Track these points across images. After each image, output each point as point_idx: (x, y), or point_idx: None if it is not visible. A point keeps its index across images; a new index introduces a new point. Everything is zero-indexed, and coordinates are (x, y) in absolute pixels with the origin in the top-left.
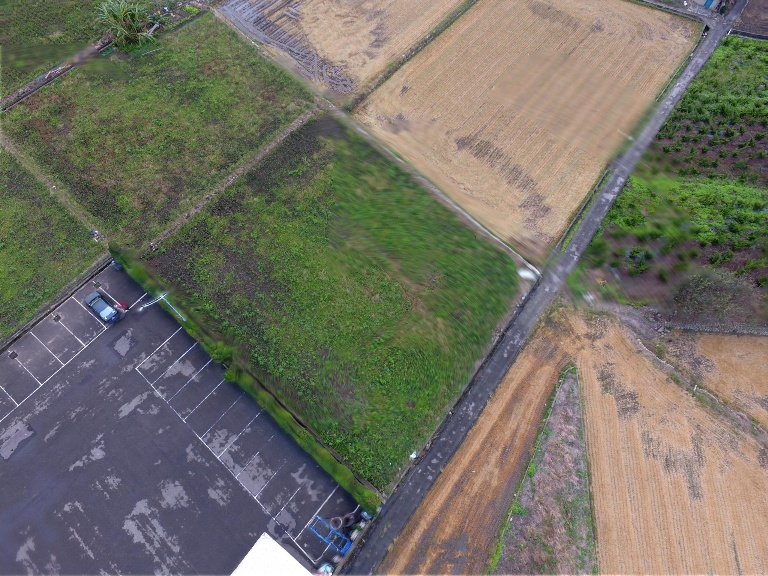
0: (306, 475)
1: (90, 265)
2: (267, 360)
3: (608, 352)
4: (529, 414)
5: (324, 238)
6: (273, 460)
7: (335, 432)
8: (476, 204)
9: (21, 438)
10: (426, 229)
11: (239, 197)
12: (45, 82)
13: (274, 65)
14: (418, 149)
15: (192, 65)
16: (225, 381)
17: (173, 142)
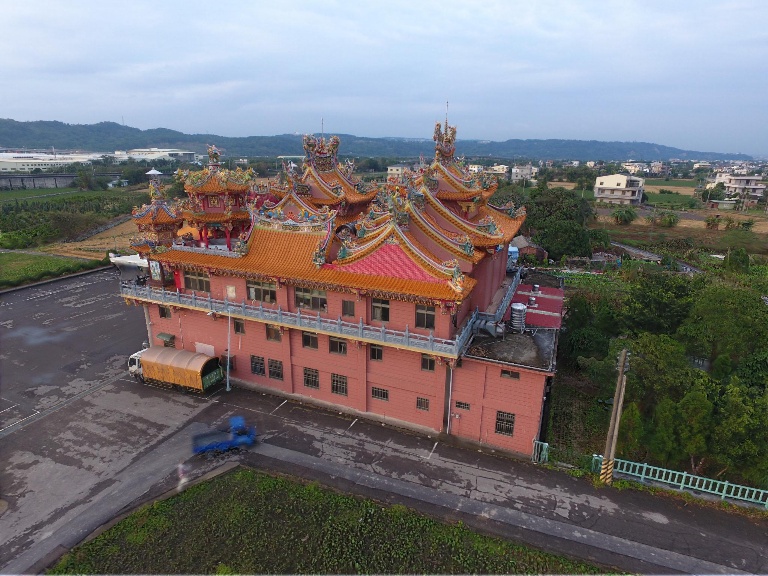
0: None
1: None
2: None
3: (76, 245)
4: (94, 253)
5: None
6: None
7: None
8: None
9: None
10: None
11: None
12: None
13: None
14: None
15: None
16: None
17: None
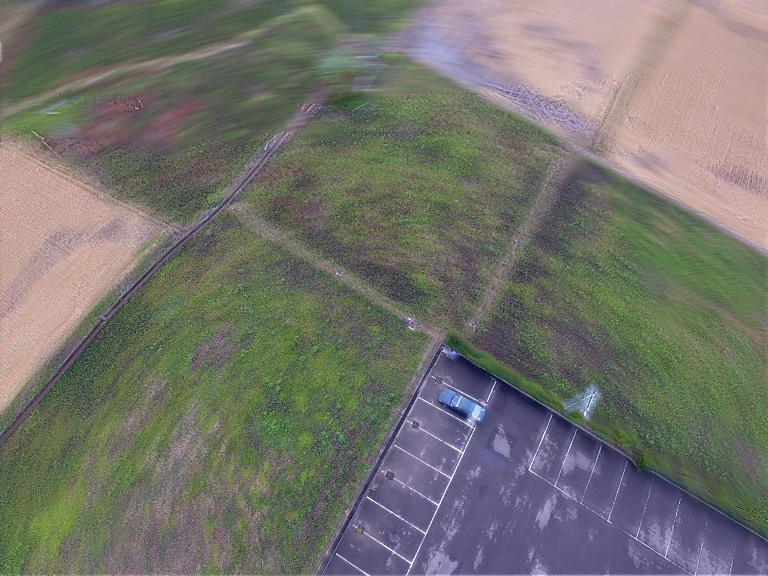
0: (763, 561)
1: (421, 358)
2: (654, 438)
3: None
4: None
5: (643, 293)
6: (722, 550)
7: (763, 507)
8: (763, 235)
9: (449, 571)
10: (737, 269)
11: (533, 259)
12: (265, 154)
13: (498, 108)
14: (677, 182)
15: (412, 117)
16: (638, 471)
17: (436, 206)
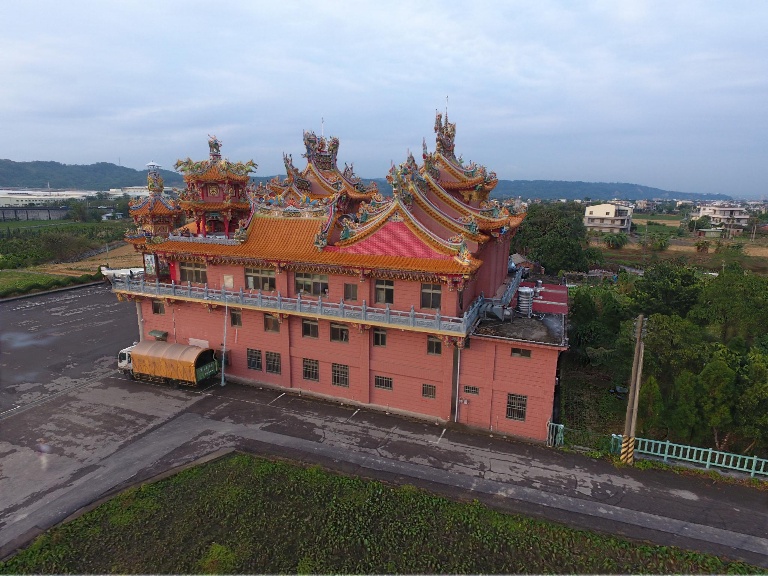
0: None
1: None
2: None
3: None
4: (85, 272)
5: None
6: None
7: None
8: None
9: None
10: None
11: None
12: None
13: None
14: None
15: None
16: None
17: None
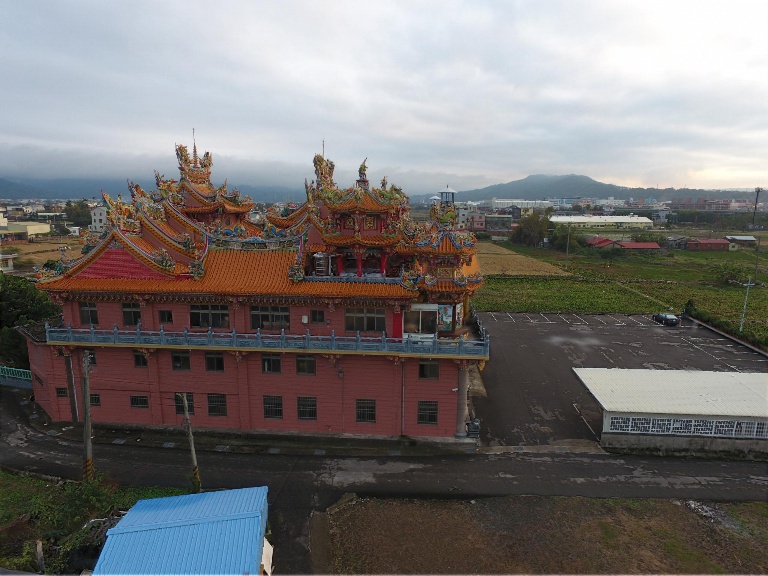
0: None
1: None
2: None
3: None
4: None
5: None
6: None
7: None
8: None
9: None
10: None
11: None
12: None
13: None
14: None
15: None
16: None
17: None
